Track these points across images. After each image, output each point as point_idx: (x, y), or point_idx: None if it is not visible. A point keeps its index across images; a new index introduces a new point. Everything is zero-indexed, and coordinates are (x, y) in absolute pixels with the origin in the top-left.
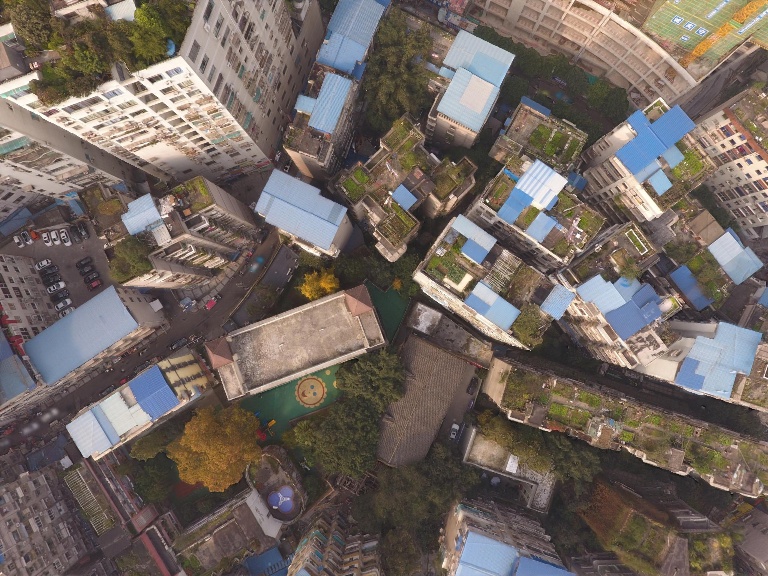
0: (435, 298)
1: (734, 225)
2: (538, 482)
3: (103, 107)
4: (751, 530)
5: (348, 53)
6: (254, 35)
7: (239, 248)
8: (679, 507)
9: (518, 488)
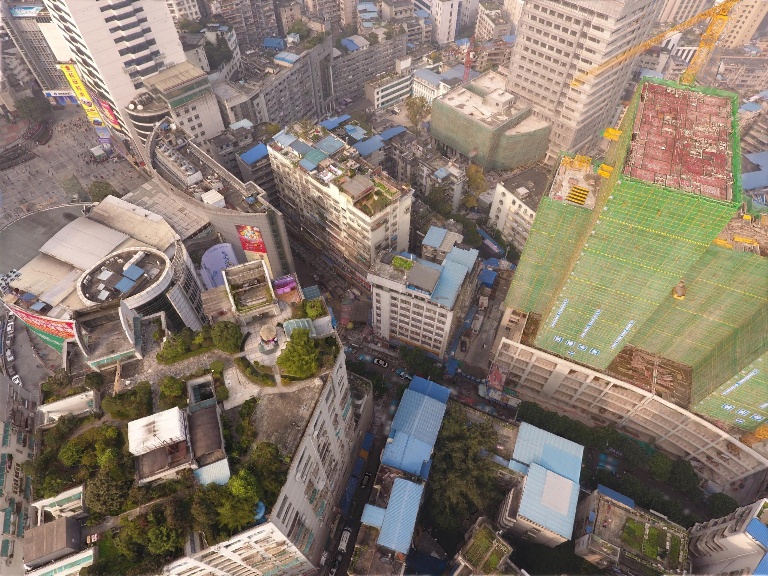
0: None
1: None
2: None
3: None
4: None
5: (414, 452)
6: None
7: None
8: None
9: None
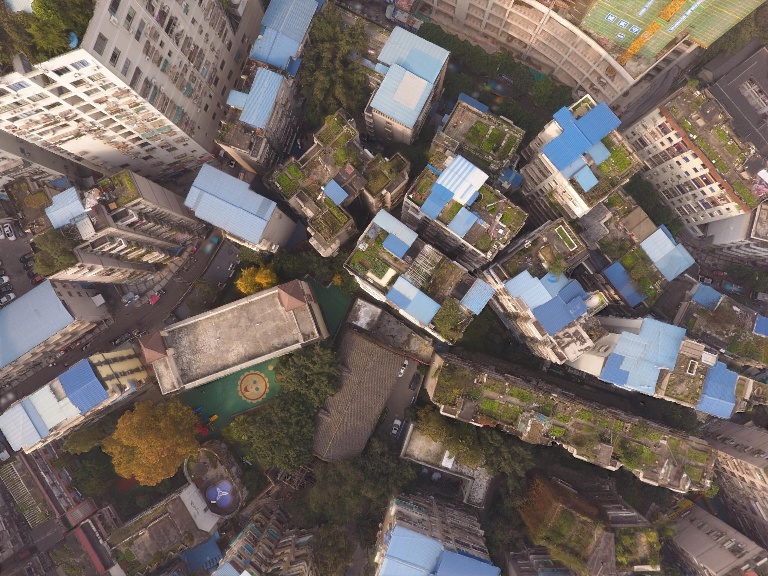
0: (372, 293)
1: (678, 223)
2: (474, 477)
3: (12, 99)
4: (688, 526)
5: (282, 48)
6: (179, 29)
7: (182, 243)
8: (612, 502)
9: (459, 483)
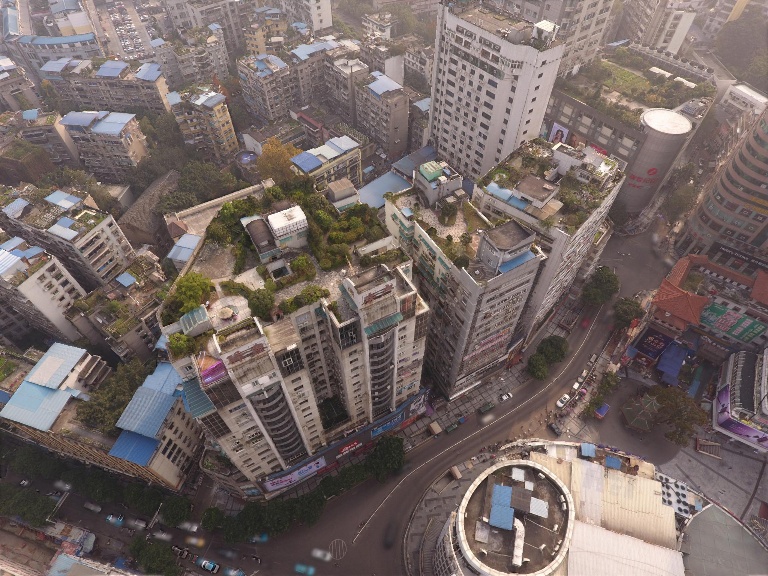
0: None
1: None
2: None
3: None
4: None
5: (159, 379)
6: None
7: None
8: None
9: None
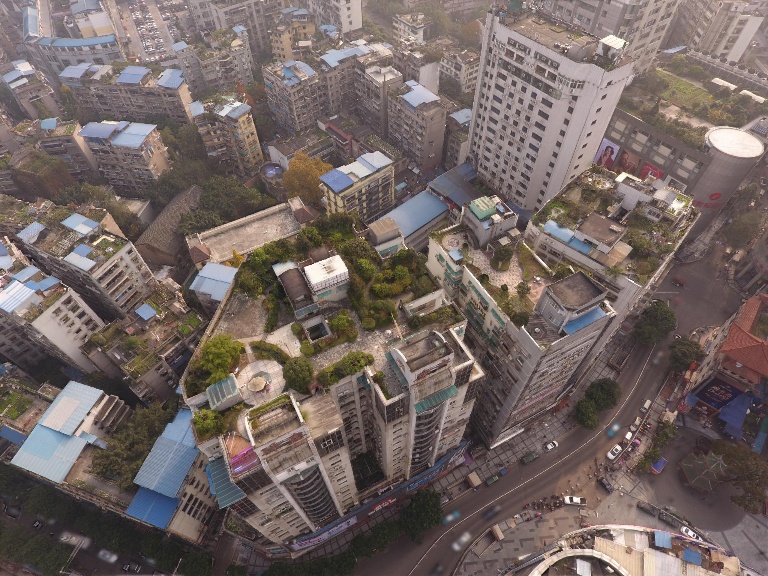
0: None
1: None
2: None
3: None
4: None
5: (180, 428)
6: None
7: None
8: None
9: None
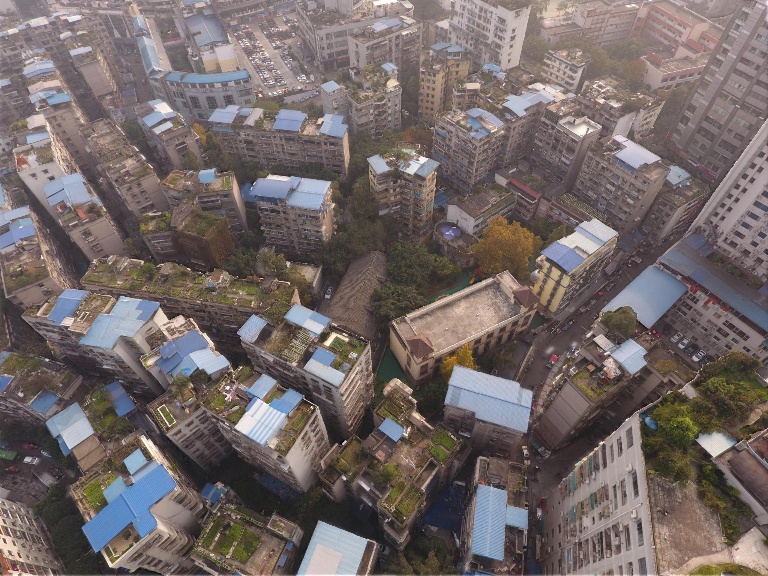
0: None
1: (40, 508)
2: None
3: None
4: None
5: None
6: None
7: None
8: (167, 255)
9: None
